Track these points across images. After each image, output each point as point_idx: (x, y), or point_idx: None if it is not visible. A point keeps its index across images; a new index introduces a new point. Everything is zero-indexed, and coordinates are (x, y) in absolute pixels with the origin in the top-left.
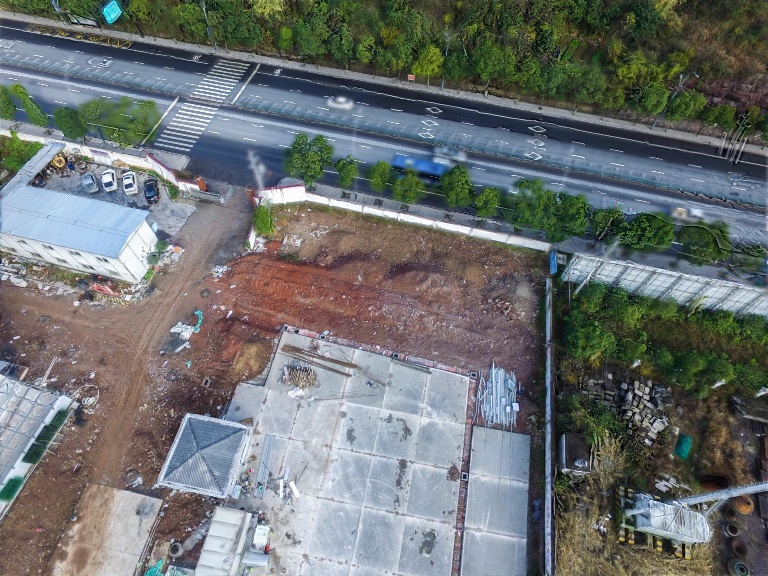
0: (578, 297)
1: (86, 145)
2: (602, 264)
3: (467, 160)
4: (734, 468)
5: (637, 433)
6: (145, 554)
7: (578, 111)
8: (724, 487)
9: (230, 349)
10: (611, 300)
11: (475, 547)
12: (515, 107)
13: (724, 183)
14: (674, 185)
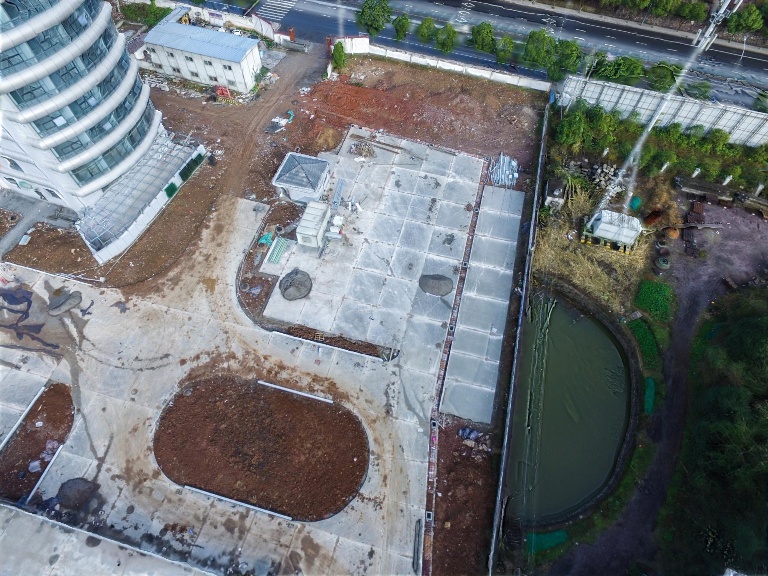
0: (568, 114)
1: None
2: (586, 84)
3: None
4: (669, 214)
5: (602, 193)
6: (260, 230)
7: (583, 10)
8: (658, 215)
9: (314, 130)
10: (592, 114)
11: (481, 243)
12: (533, 6)
13: (694, 61)
14: (653, 60)
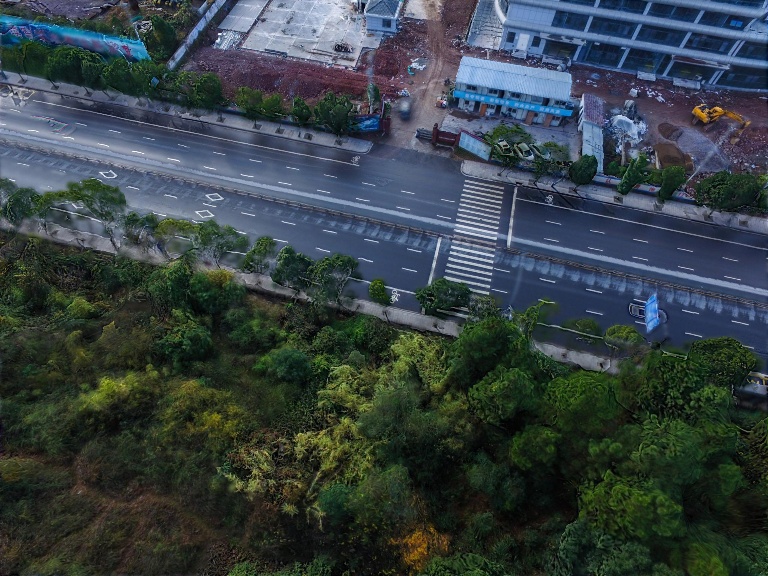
0: None
1: (567, 180)
2: None
3: (181, 169)
4: (118, 11)
5: None
6: None
7: None
8: None
9: None
10: None
11: (260, 3)
12: (88, 233)
13: None
14: None
